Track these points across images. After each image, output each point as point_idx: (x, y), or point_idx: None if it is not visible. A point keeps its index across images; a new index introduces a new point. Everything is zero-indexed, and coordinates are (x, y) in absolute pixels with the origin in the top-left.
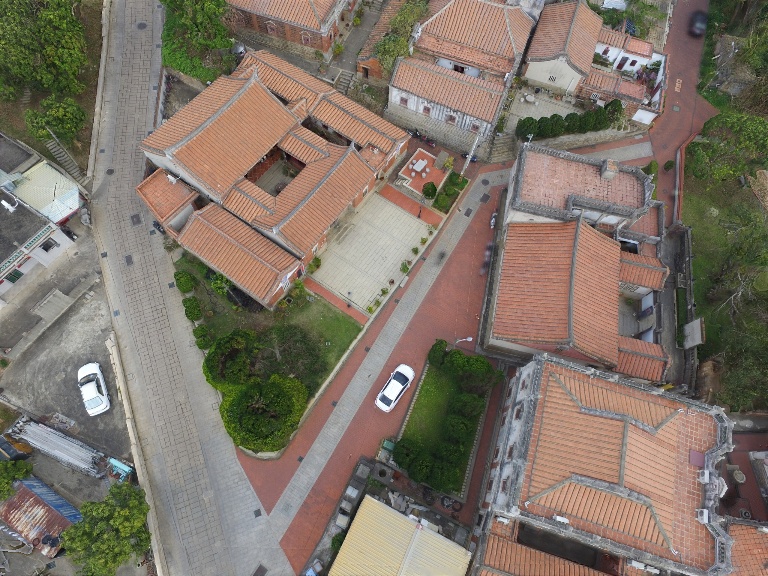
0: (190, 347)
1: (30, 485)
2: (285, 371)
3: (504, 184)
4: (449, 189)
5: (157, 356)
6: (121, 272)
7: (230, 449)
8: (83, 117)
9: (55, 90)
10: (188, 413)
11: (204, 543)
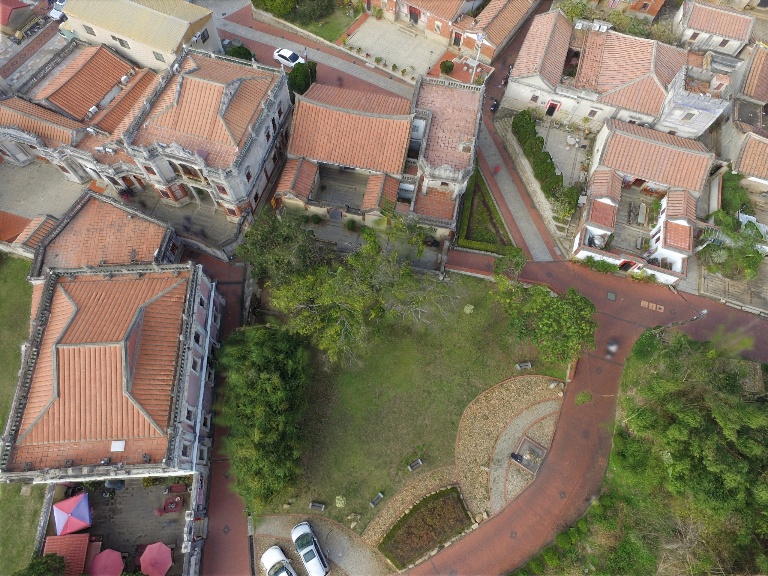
0: None
1: None
2: None
3: None
4: None
5: None
6: None
7: None
8: None
9: None
10: None
11: None
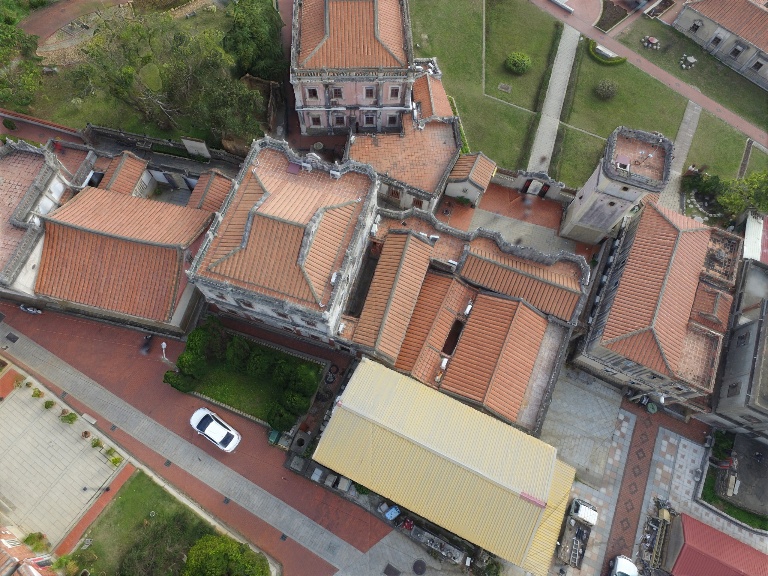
0: None
1: None
2: (178, 569)
3: None
4: None
5: None
6: None
7: None
8: None
9: None
10: None
11: None
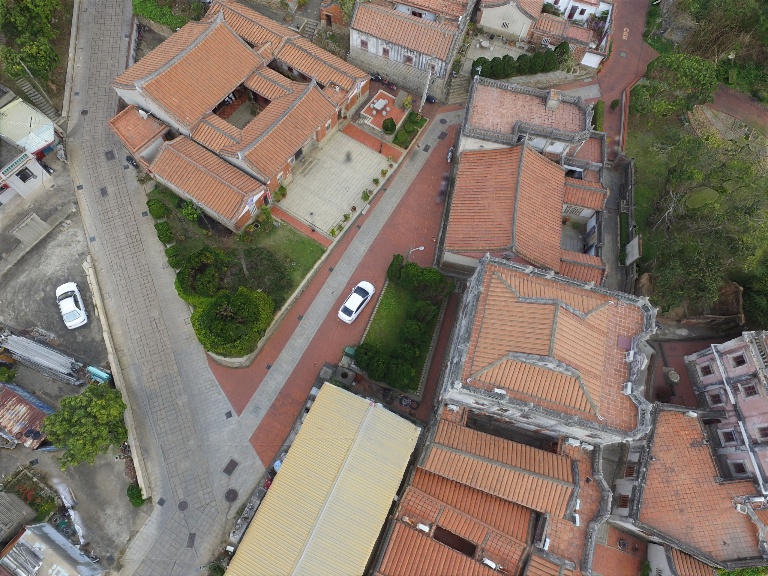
0: (163, 269)
1: (12, 388)
2: (253, 287)
3: (461, 123)
4: (408, 126)
5: (132, 277)
6: (96, 203)
7: (202, 359)
8: (57, 58)
9: (29, 34)
10: (162, 327)
11: (178, 441)
